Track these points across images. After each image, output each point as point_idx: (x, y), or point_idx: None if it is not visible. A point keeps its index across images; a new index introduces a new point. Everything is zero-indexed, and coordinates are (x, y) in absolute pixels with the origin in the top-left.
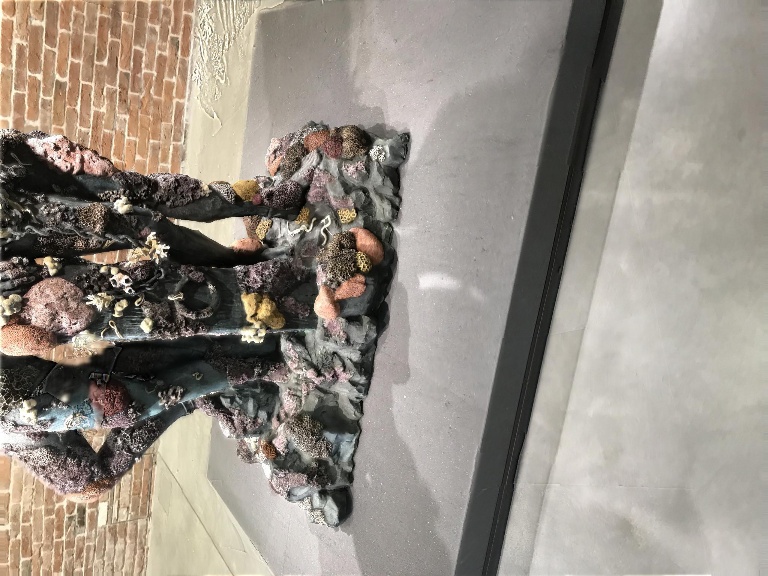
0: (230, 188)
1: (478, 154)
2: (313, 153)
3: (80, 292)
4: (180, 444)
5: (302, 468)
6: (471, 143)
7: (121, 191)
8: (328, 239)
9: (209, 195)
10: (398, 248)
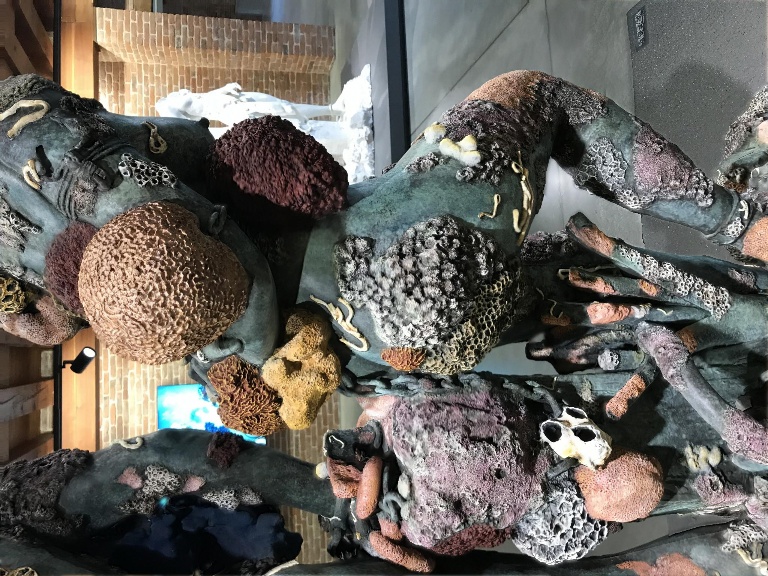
0: None
1: None
2: None
3: None
4: None
5: None
6: None
7: None
8: None
9: None
10: None
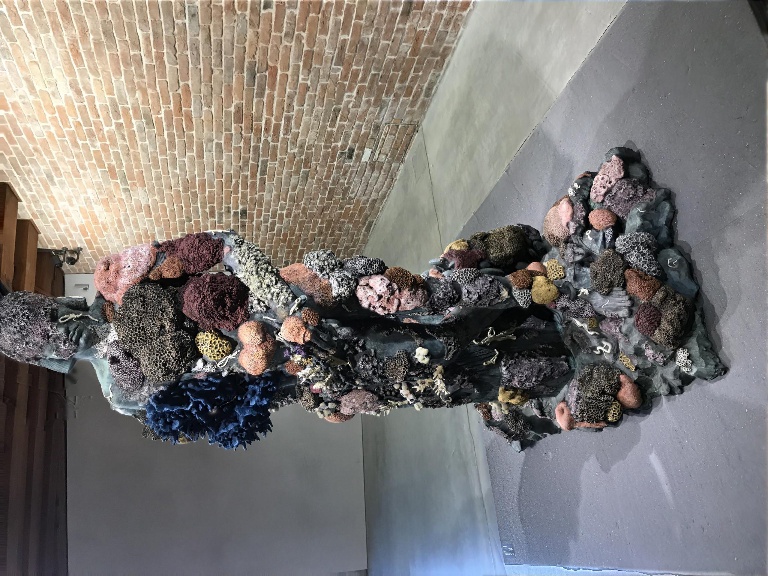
0: (528, 297)
1: (755, 492)
2: (626, 300)
3: (376, 398)
4: (440, 151)
5: (506, 428)
6: (759, 476)
7: (426, 313)
8: (601, 355)
9: (506, 299)
10: (655, 410)
